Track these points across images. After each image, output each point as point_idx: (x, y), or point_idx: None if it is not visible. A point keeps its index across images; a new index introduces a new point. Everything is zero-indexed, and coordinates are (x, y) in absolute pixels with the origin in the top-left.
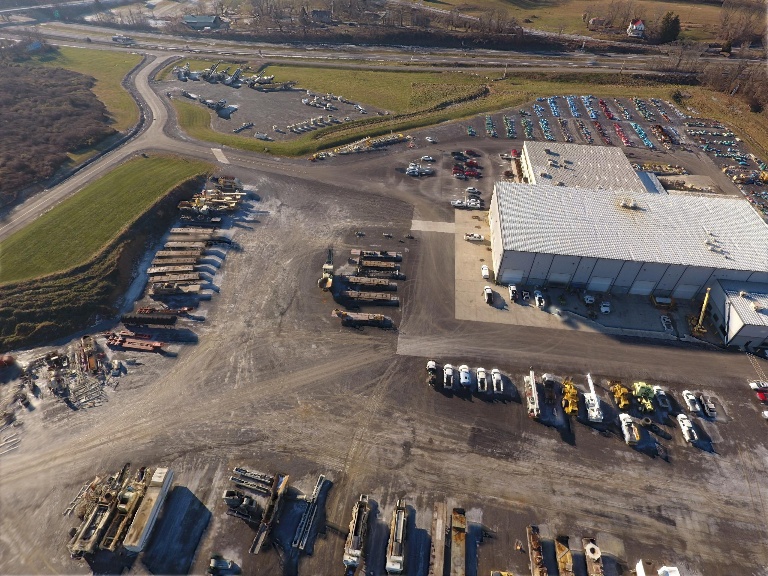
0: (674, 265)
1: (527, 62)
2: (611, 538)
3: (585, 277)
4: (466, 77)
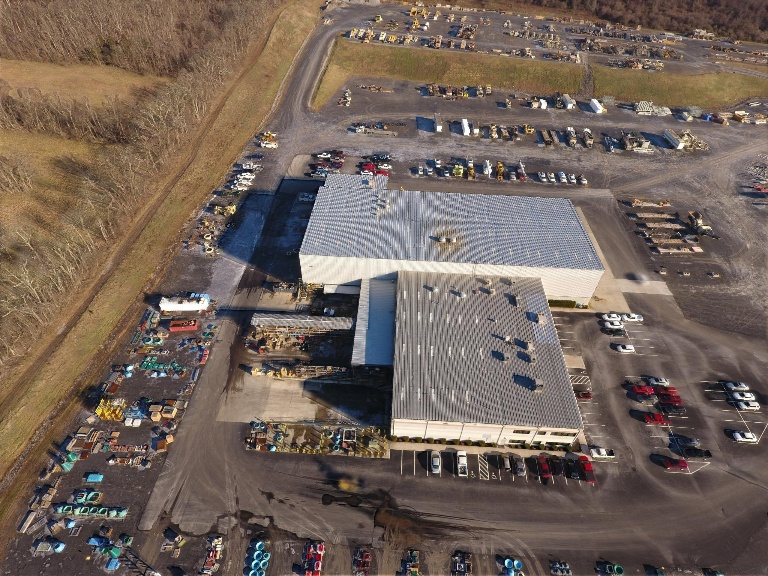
0: None
1: None
2: (485, 141)
3: None
4: None
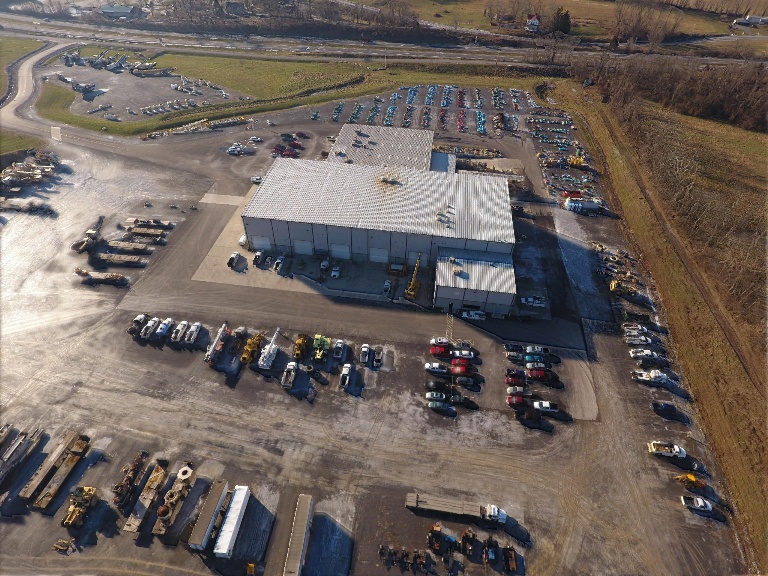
0: (394, 232)
1: (416, 54)
2: (216, 464)
3: (324, 244)
4: (349, 67)
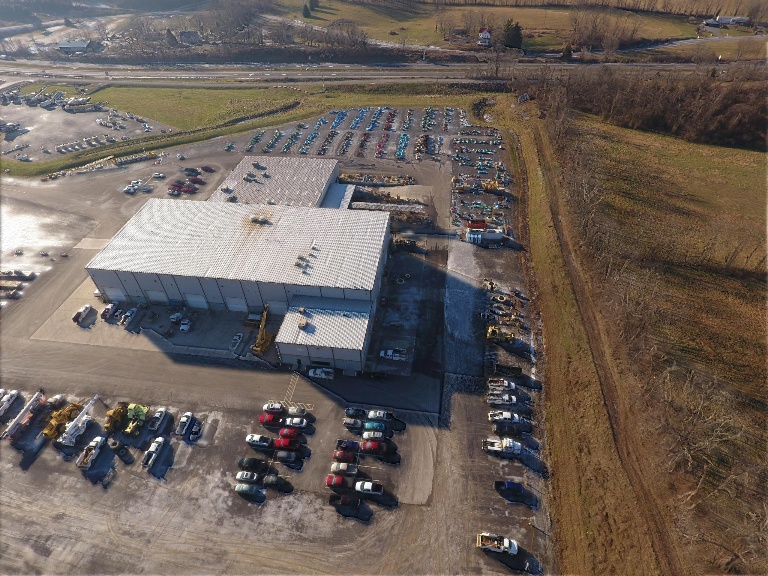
0: (243, 281)
1: (360, 75)
2: None
3: (177, 294)
4: (288, 92)
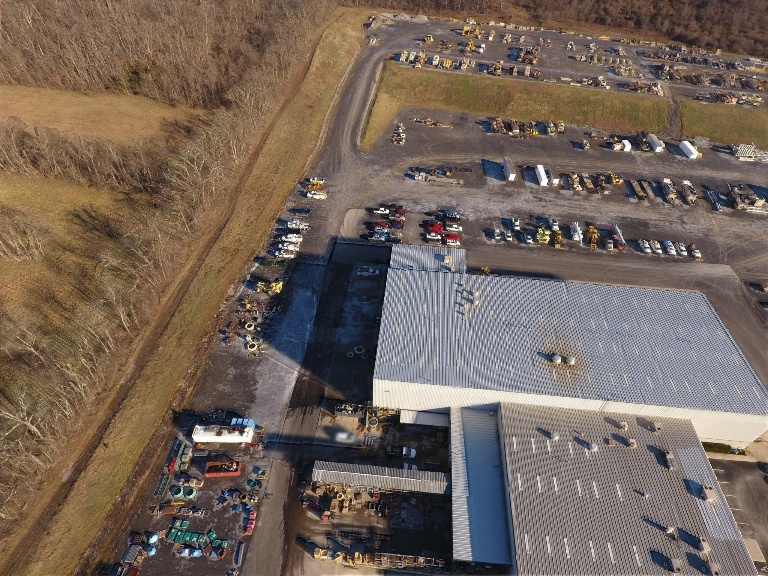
0: None
1: None
2: (566, 194)
3: None
4: None
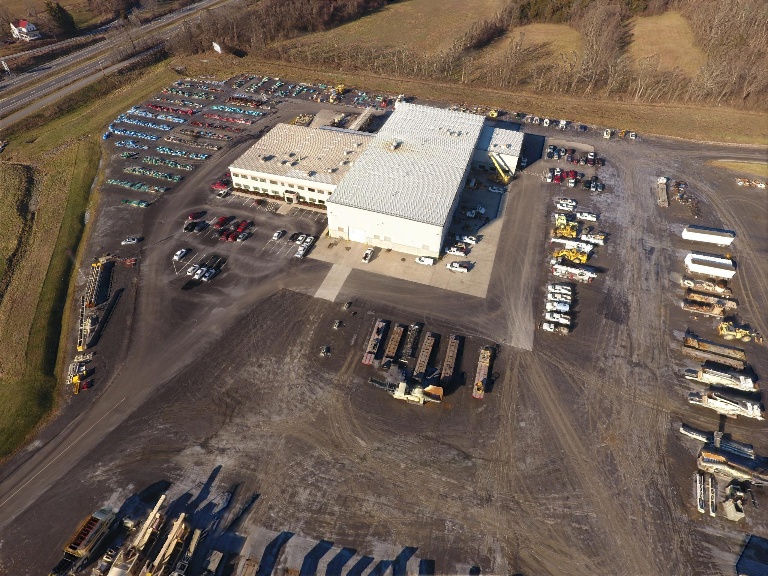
0: None
1: None
2: (672, 275)
3: None
4: None
